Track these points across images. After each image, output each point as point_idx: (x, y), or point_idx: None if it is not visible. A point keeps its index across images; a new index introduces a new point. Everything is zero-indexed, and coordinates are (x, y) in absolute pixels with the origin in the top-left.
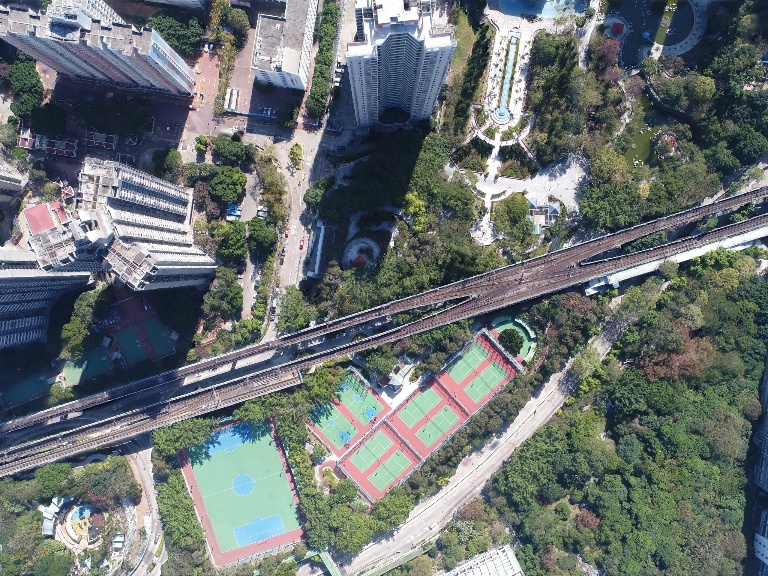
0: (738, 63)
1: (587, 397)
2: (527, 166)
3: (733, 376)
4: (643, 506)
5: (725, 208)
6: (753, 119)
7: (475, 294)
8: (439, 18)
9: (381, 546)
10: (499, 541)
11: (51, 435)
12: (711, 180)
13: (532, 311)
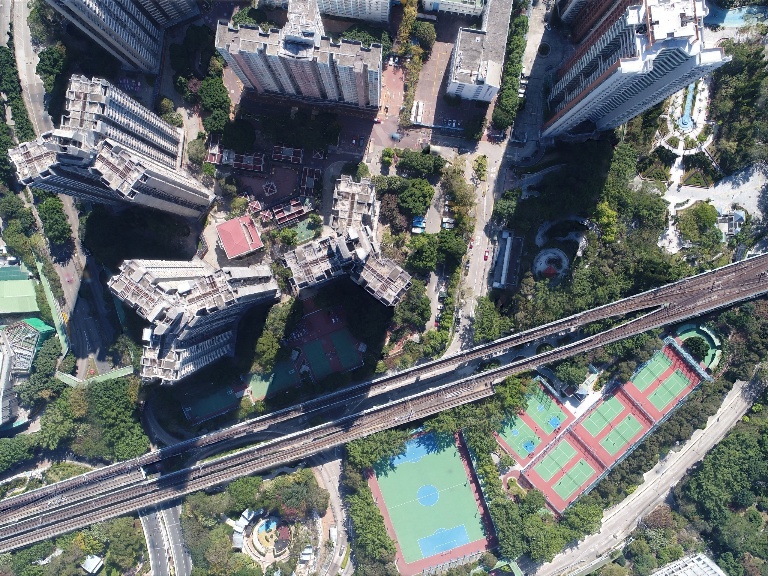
0: None
1: None
2: (711, 174)
3: None
4: None
5: None
6: None
7: (667, 303)
8: None
9: (566, 555)
10: (690, 549)
11: (238, 448)
12: None
13: (720, 319)
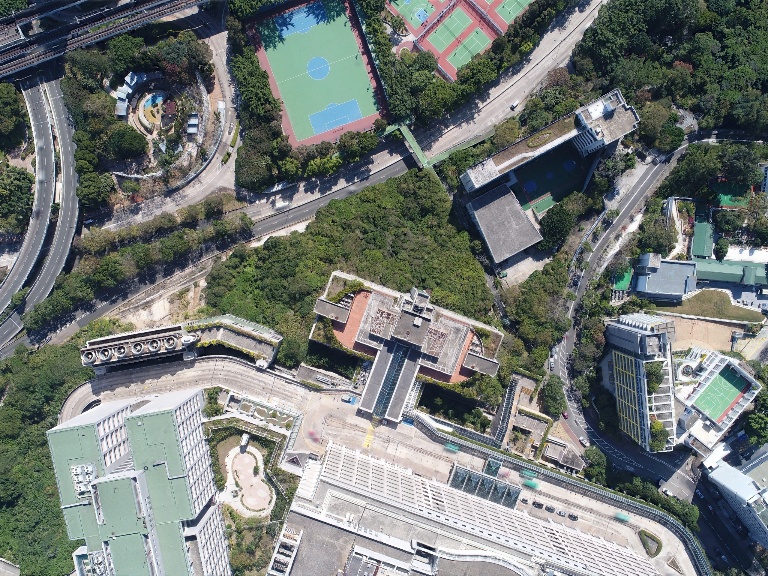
0: None
1: None
2: None
3: None
4: (740, 47)
5: None
6: None
7: None
8: None
9: (462, 129)
10: None
11: (121, 18)
12: None
13: None
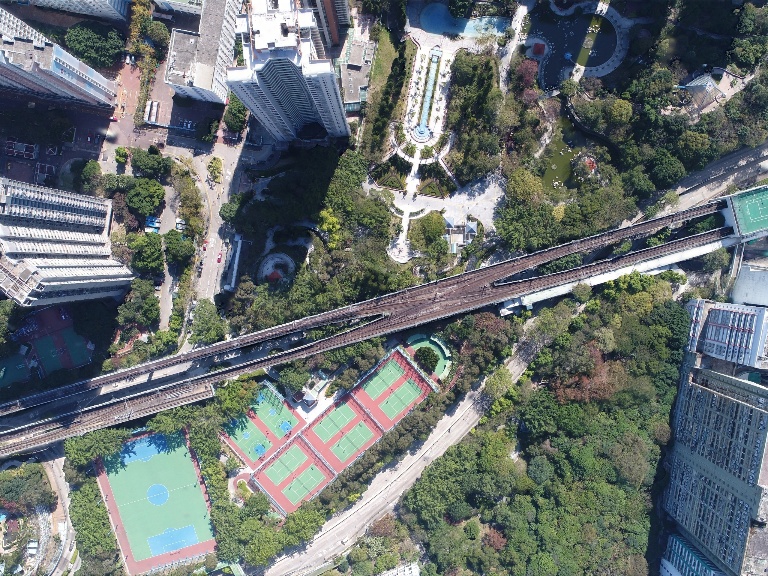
0: (653, 88)
1: (500, 417)
2: (446, 185)
3: (644, 400)
4: (549, 528)
5: (640, 232)
6: (669, 144)
7: (388, 312)
8: (361, 35)
9: (294, 559)
10: (408, 558)
11: None
12: (626, 204)
13: (446, 330)
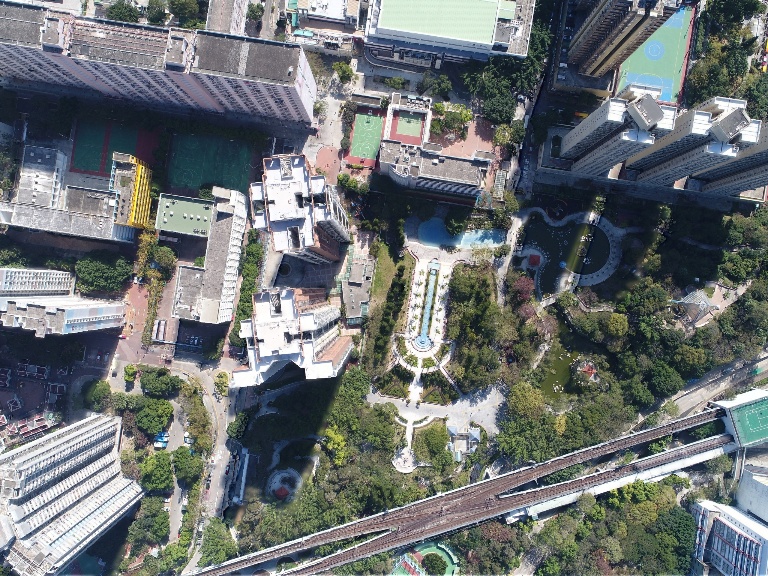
0: (648, 306)
1: None
2: (448, 393)
3: None
4: None
5: (642, 441)
6: (666, 356)
7: (395, 527)
8: (361, 249)
9: None
10: None
11: None
12: (626, 416)
13: (453, 540)
